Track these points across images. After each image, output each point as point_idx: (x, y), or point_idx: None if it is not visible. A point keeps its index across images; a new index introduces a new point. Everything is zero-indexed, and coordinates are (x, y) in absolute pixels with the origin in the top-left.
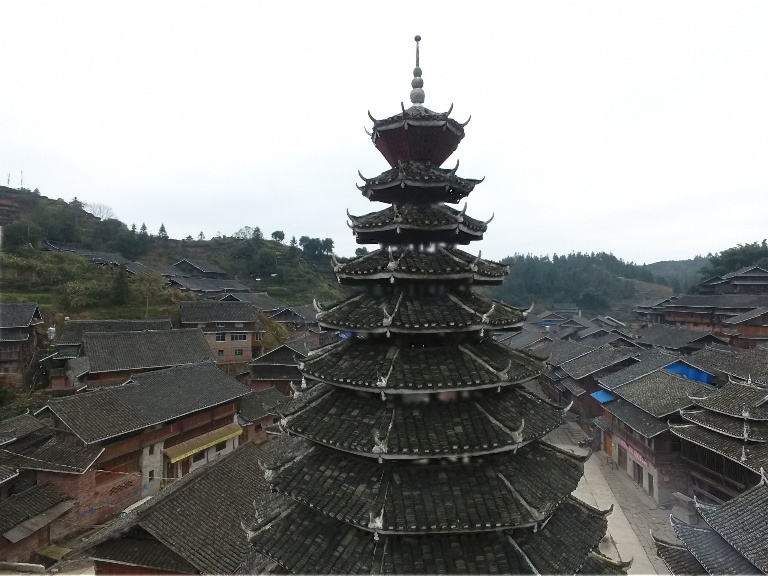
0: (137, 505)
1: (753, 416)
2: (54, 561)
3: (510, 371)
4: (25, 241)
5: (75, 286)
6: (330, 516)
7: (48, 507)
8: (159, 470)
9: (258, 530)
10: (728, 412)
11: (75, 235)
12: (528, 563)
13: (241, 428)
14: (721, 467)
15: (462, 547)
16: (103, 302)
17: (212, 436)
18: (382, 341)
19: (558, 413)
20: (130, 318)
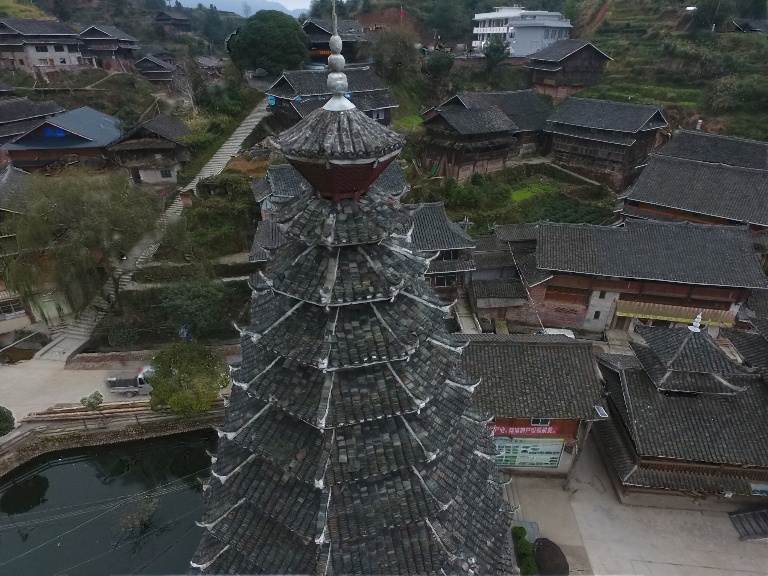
0: (553, 331)
1: None
2: (494, 331)
3: (269, 445)
4: (710, 22)
5: (728, 82)
6: None
7: (510, 297)
8: (607, 314)
9: None
10: None
11: (767, 9)
12: None
13: (733, 322)
14: None
15: None
16: (750, 105)
17: (683, 312)
18: None
19: (315, 532)
20: (767, 131)
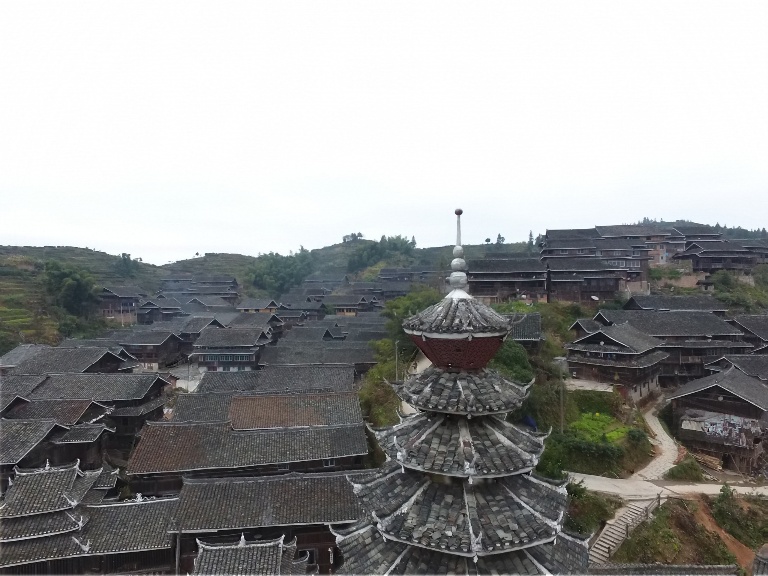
0: None
1: (78, 501)
2: None
3: None
4: None
5: None
6: None
7: None
8: None
9: None
10: (50, 509)
11: None
12: None
13: None
14: (45, 574)
15: None
16: None
17: None
18: None
19: None
20: None
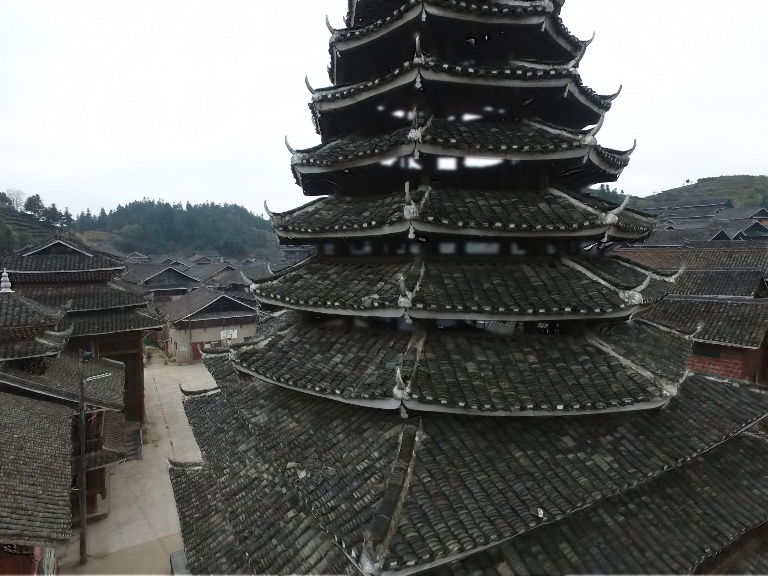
0: None
1: None
2: None
3: None
4: None
5: None
6: (547, 229)
7: None
8: None
9: (413, 290)
10: None
11: None
12: (640, 271)
13: None
14: None
15: (603, 266)
16: None
17: None
18: (499, 51)
19: None
20: None
